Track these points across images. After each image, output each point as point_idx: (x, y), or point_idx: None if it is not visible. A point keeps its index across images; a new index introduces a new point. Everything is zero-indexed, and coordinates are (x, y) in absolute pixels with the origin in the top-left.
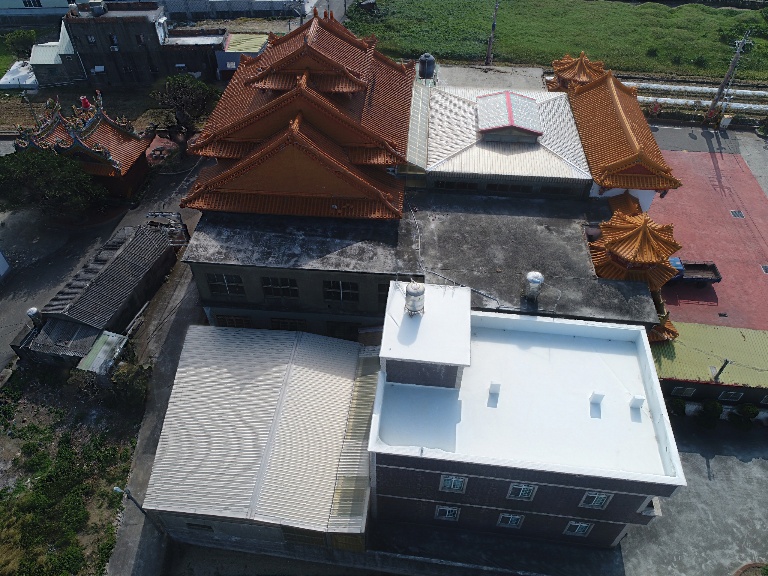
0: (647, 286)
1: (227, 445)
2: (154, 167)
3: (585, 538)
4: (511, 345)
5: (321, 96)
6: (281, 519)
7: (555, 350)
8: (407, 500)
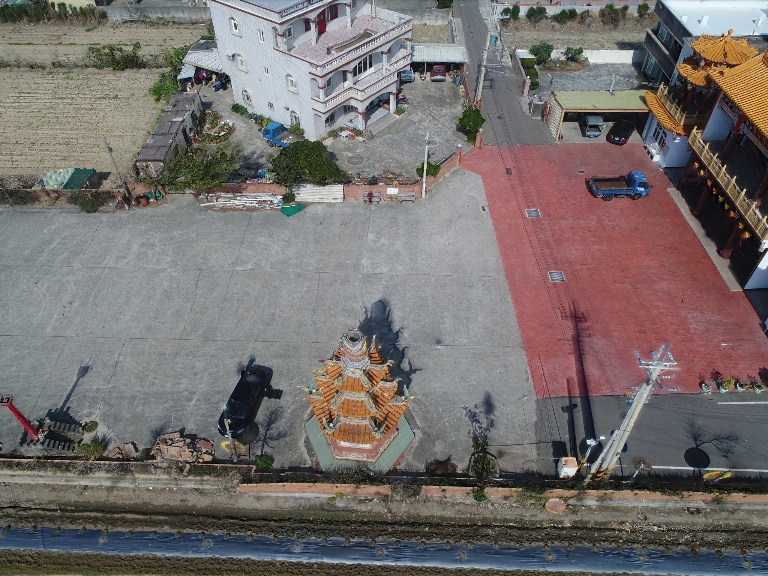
0: None
1: None
2: None
3: None
4: None
5: None
6: None
7: None
8: None
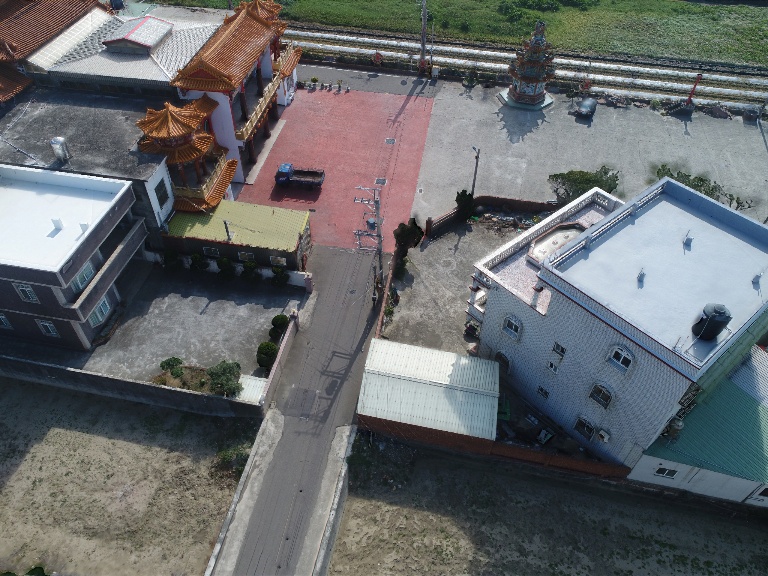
0: (164, 158)
1: None
2: None
3: (62, 339)
4: (32, 192)
5: None
6: None
7: (62, 196)
8: None
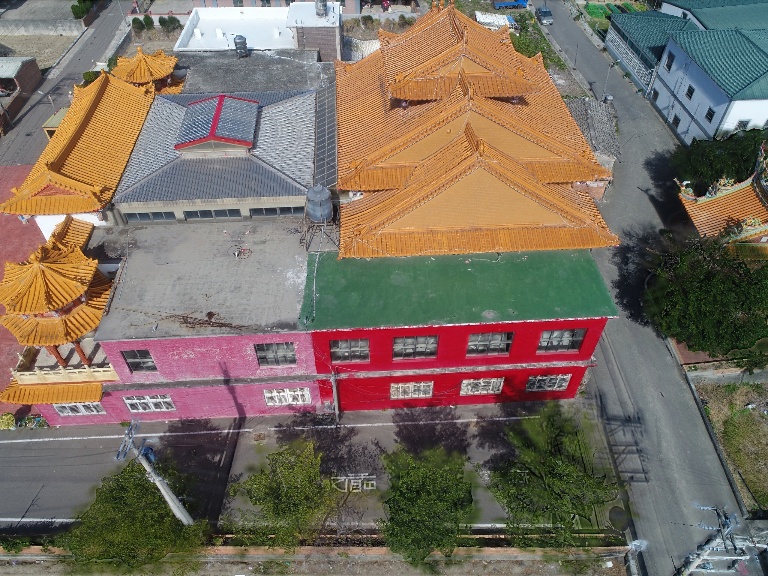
0: None
1: None
2: None
3: None
4: None
5: None
6: None
7: None
8: None
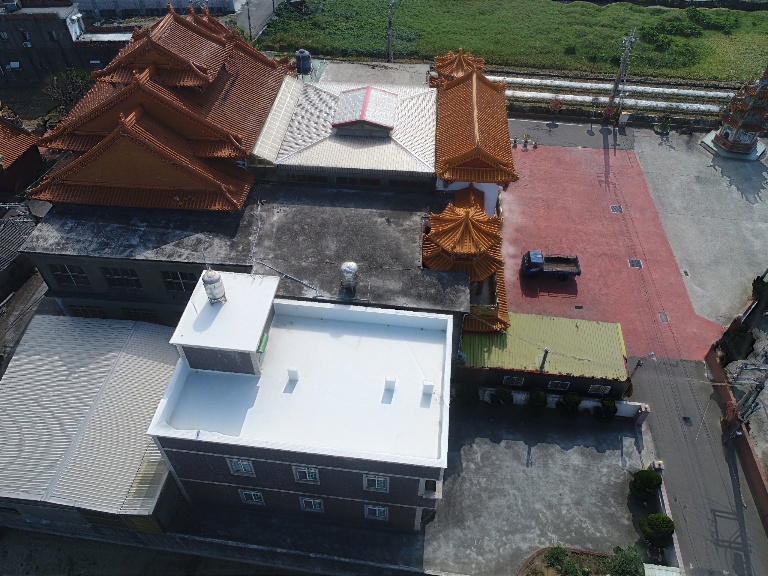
0: (468, 277)
1: (41, 430)
2: (49, 161)
3: (387, 522)
4: (324, 333)
5: (165, 90)
6: (76, 501)
7: (365, 338)
8: (209, 484)
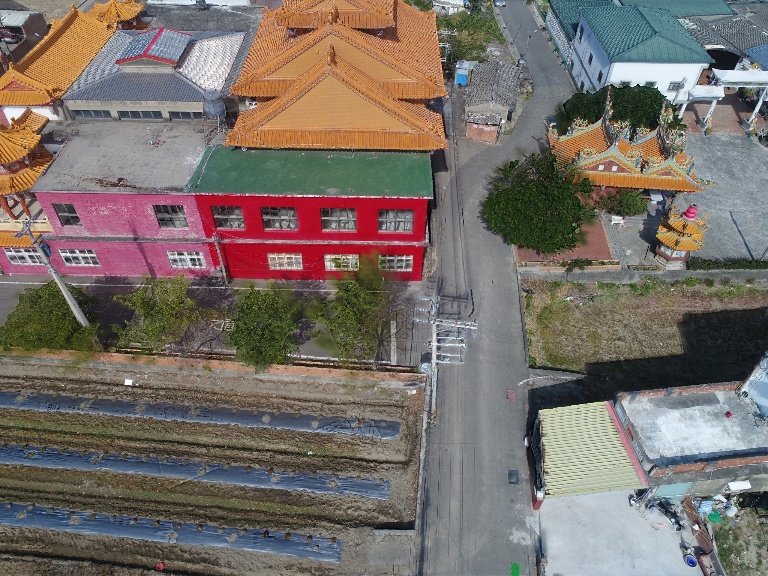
0: None
1: None
2: None
3: None
4: None
5: None
6: None
7: None
8: None
